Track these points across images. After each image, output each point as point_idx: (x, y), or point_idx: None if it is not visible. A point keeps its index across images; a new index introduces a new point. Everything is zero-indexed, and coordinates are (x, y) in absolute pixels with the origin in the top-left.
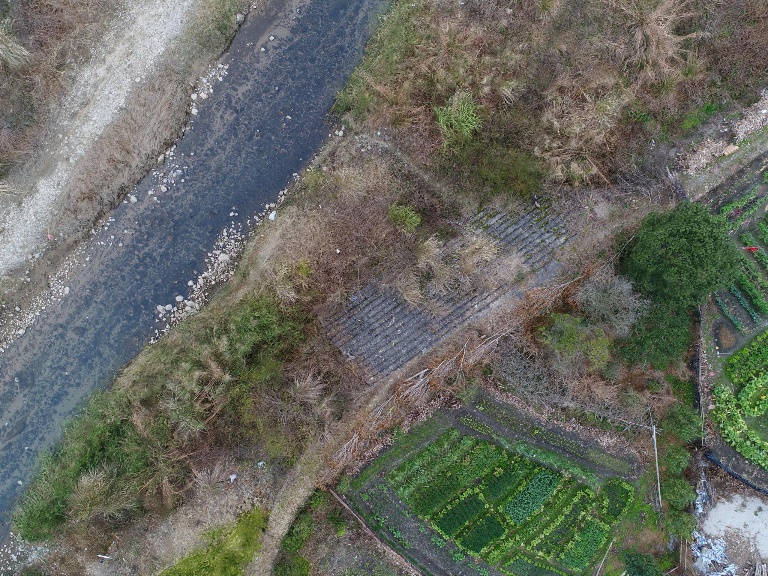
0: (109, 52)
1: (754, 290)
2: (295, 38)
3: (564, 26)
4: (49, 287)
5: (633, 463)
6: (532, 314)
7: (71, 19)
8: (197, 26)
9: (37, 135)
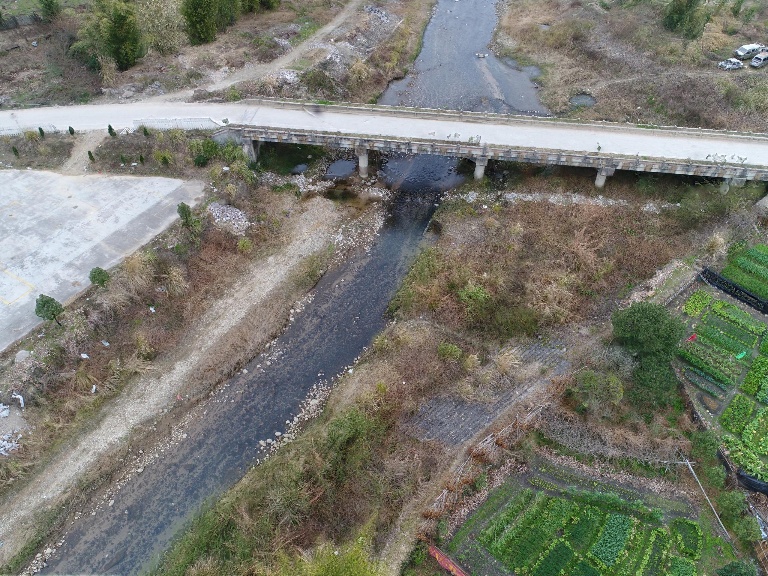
0: (237, 291)
1: (711, 368)
2: (357, 280)
3: (525, 257)
4: (170, 435)
5: (687, 504)
6: (560, 392)
7: (216, 274)
8: (295, 276)
9: (181, 335)
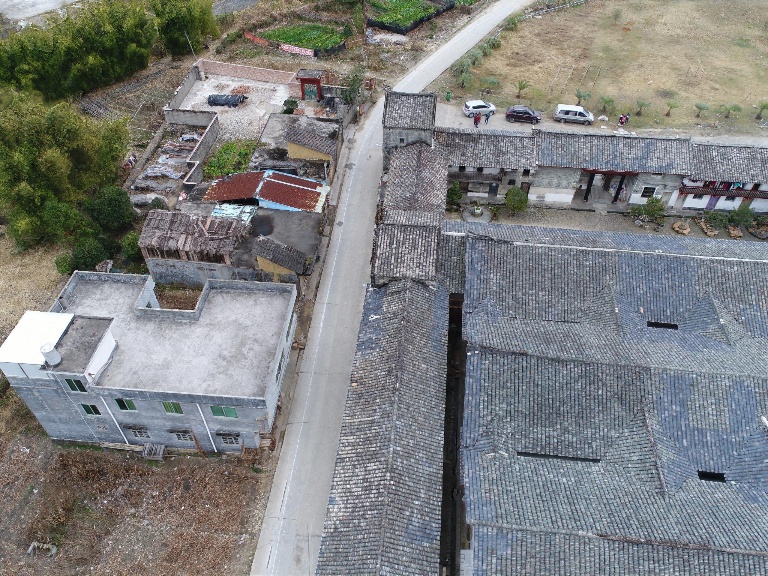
0: None
1: (383, 6)
2: None
3: None
4: None
5: None
6: (313, 7)
7: None
8: None
9: None
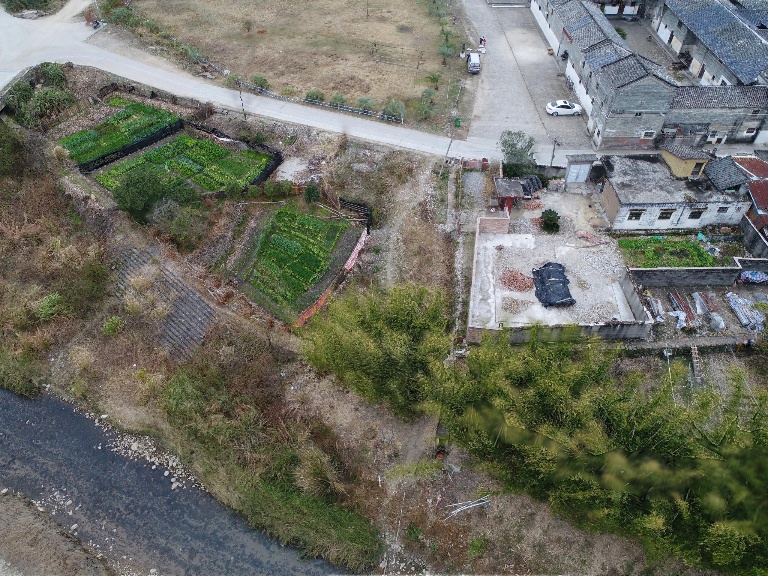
0: None
1: (170, 184)
2: None
3: (4, 277)
4: None
5: None
6: None
7: None
8: None
9: None
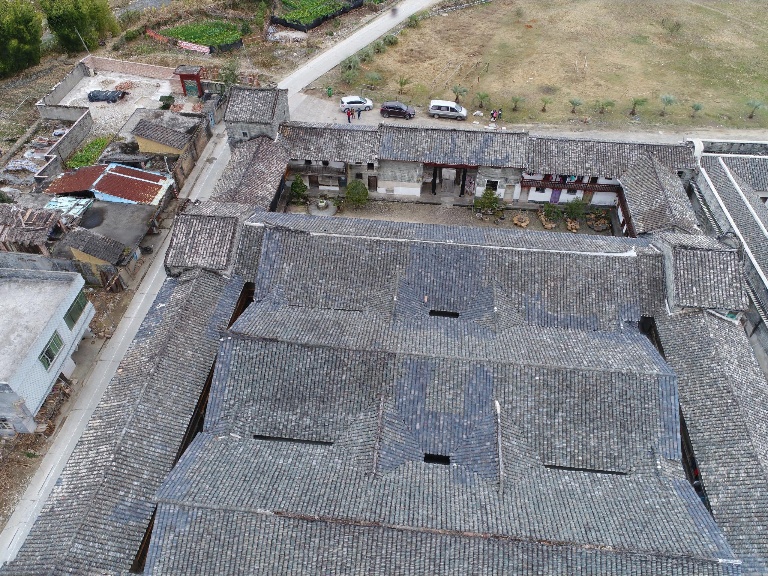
0: None
1: (292, 3)
2: None
3: None
4: None
5: None
6: (222, 5)
7: None
8: None
9: None
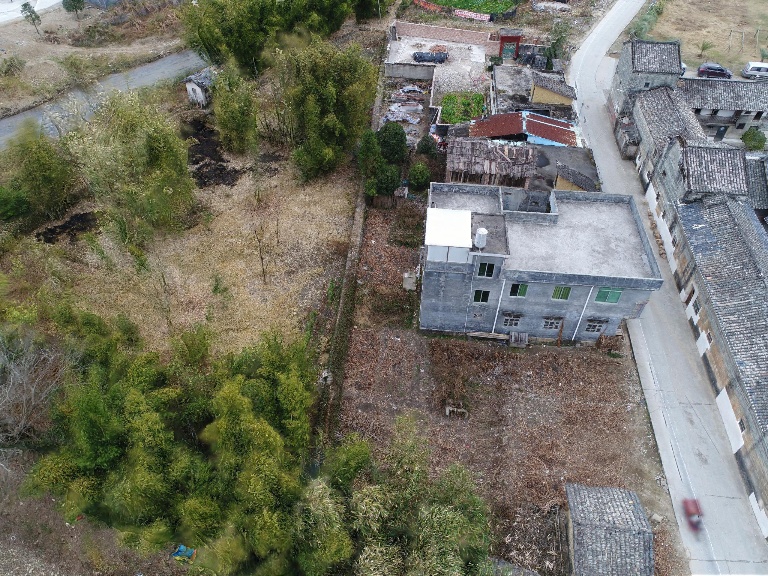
0: None
1: None
2: None
3: None
4: None
5: None
6: None
7: None
8: None
9: None
